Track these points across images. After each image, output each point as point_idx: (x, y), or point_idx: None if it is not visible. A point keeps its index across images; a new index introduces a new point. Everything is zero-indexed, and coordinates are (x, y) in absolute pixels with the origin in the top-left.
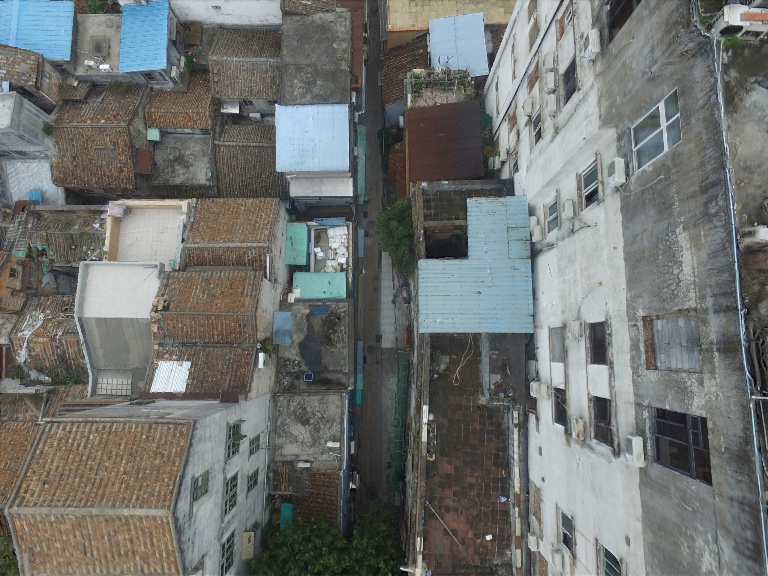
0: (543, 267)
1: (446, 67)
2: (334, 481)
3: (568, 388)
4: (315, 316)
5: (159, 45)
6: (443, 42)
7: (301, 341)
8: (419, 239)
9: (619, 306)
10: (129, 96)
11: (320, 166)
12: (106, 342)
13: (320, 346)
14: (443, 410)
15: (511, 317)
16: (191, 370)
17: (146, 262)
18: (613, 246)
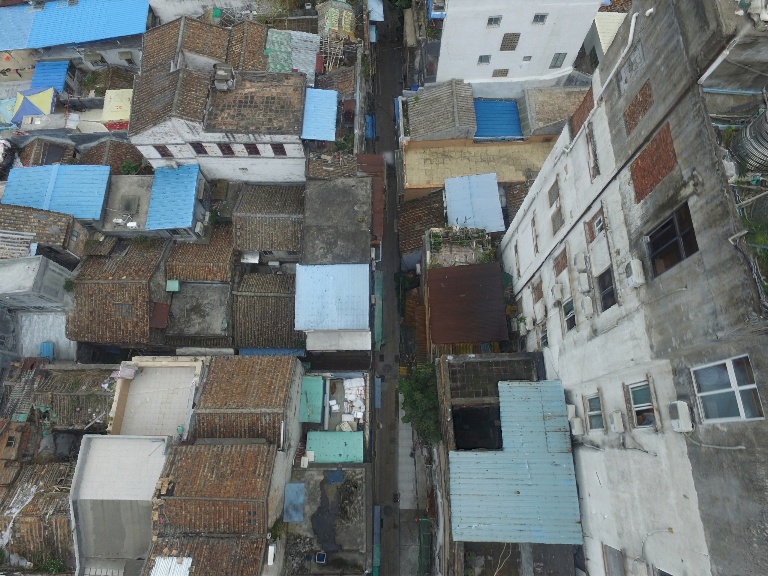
0: (587, 465)
1: (464, 227)
2: None
3: None
4: (330, 484)
5: (186, 205)
6: (459, 199)
7: (314, 513)
8: (446, 418)
9: (701, 574)
10: (152, 250)
11: (339, 325)
12: (100, 527)
13: (334, 520)
14: None
15: (556, 524)
16: (192, 569)
17: (153, 436)
18: (683, 493)
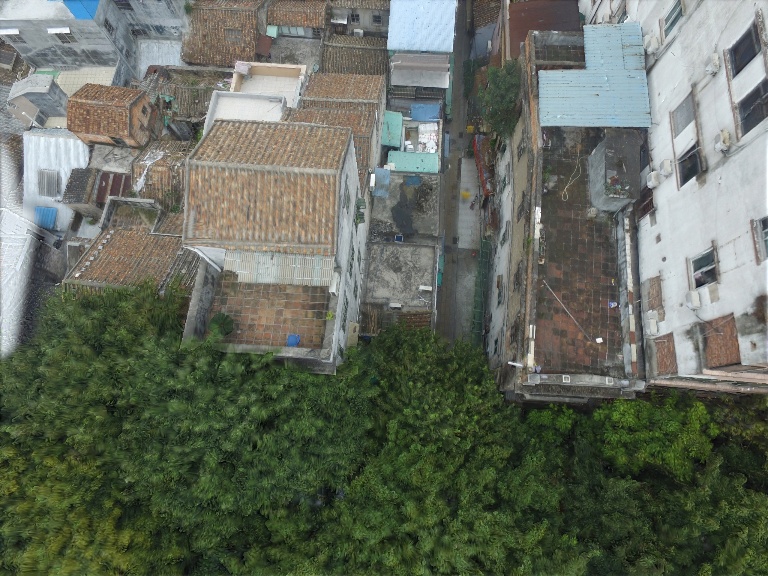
0: (659, 72)
1: None
2: (426, 320)
3: (701, 132)
4: (408, 186)
5: None
6: None
7: (394, 206)
8: (531, 74)
9: None
10: None
11: (427, 47)
12: None
13: (412, 212)
14: (552, 221)
15: (629, 114)
16: None
17: (272, 95)
18: None
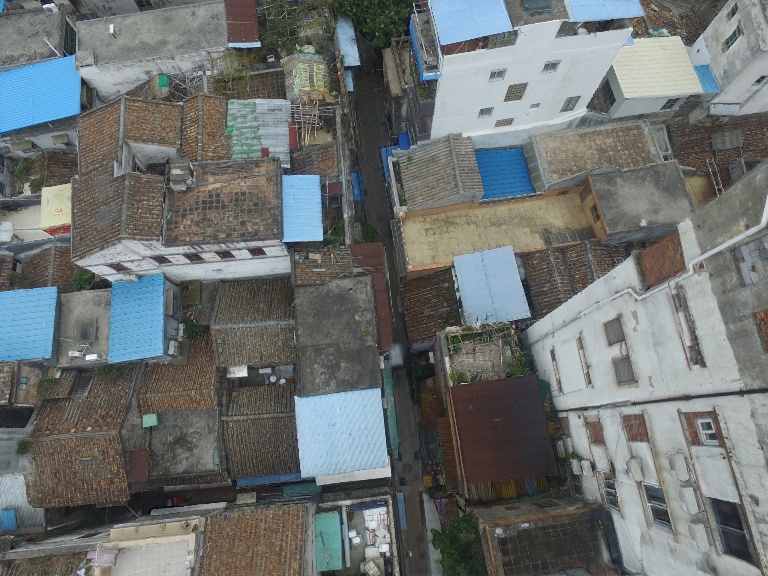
0: None
1: (486, 326)
2: None
3: None
4: None
5: (154, 327)
6: (473, 282)
7: None
8: None
9: None
10: (120, 383)
11: (353, 465)
12: None
13: None
14: None
15: None
16: None
17: None
18: None
